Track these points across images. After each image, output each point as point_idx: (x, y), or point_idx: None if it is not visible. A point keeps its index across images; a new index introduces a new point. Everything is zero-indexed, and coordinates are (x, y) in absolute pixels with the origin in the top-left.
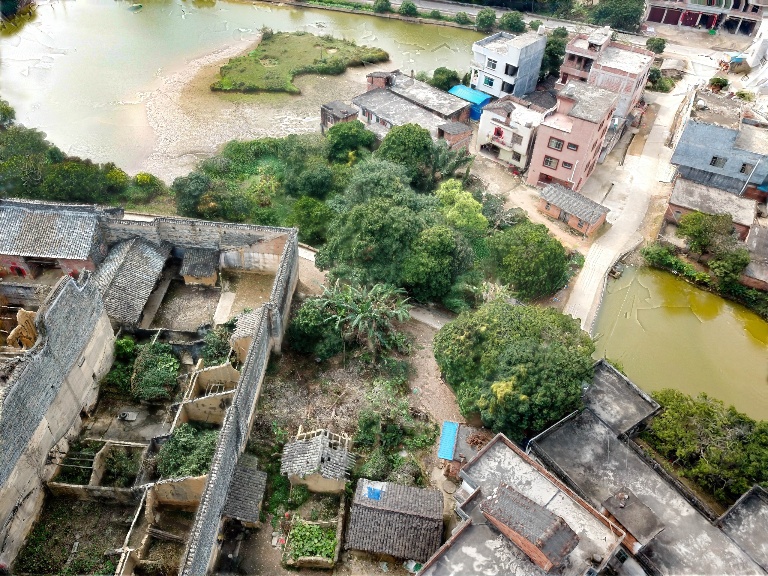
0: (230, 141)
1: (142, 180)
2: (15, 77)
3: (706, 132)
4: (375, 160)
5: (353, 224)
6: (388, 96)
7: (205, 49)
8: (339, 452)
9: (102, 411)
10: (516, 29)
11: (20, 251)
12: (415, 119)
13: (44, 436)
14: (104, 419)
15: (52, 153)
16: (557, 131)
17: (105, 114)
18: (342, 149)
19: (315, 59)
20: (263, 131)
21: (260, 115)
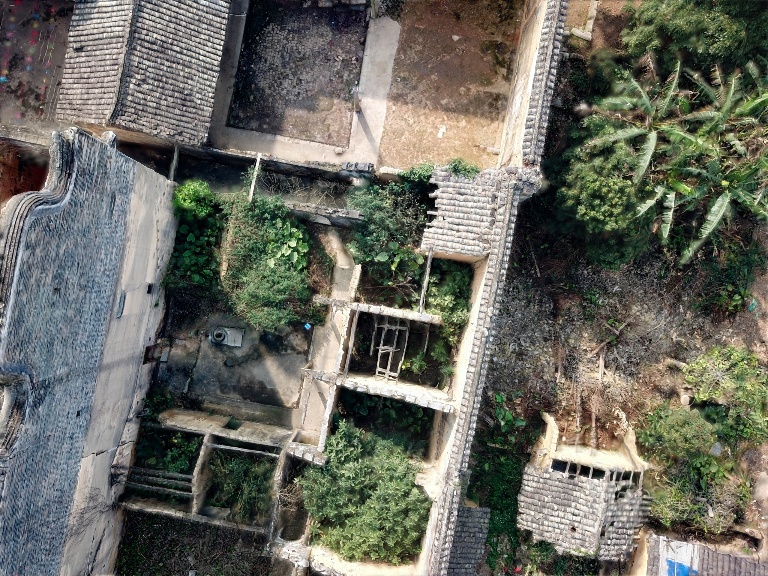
0: None
1: None
2: None
3: None
4: None
5: None
6: None
7: None
8: (629, 503)
9: (179, 322)
10: None
11: None
12: None
13: (94, 473)
14: (186, 341)
15: None
16: None
17: None
18: None
19: None
20: None
21: None
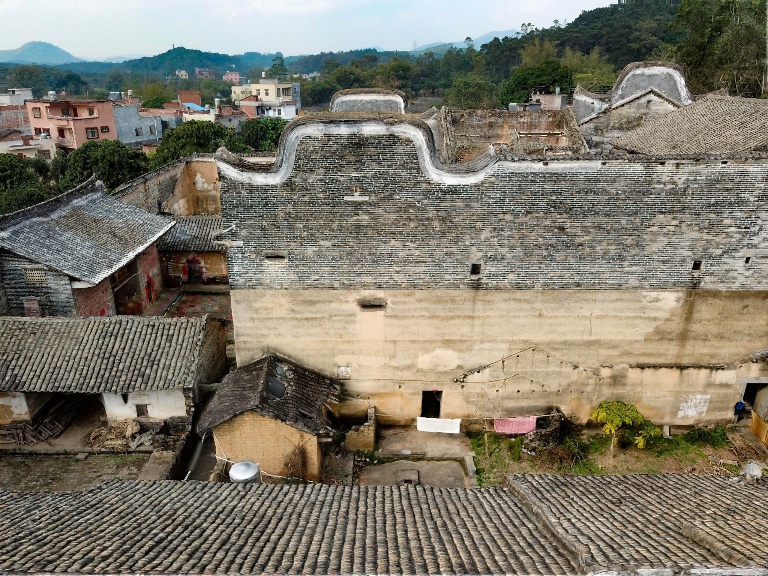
0: None
1: None
2: None
3: (123, 112)
4: None
5: (197, 140)
6: None
7: None
8: None
9: None
10: None
11: (130, 250)
12: None
13: None
14: None
15: None
16: (88, 120)
17: None
18: None
19: None
20: None
21: None
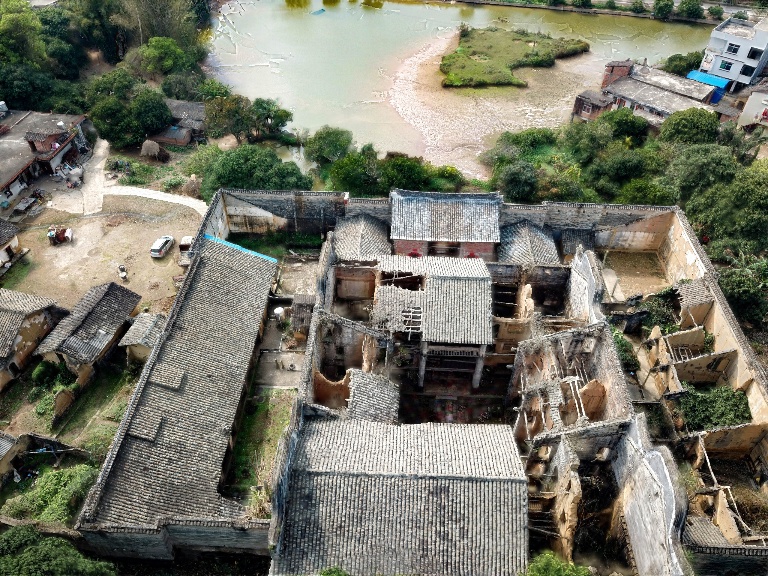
0: (504, 133)
1: (451, 172)
2: (254, 83)
3: None
4: (665, 144)
5: (735, 200)
6: (636, 84)
7: (410, 48)
8: None
9: None
10: (696, 15)
11: (437, 237)
12: (676, 104)
13: None
14: None
15: (369, 150)
16: None
17: (360, 113)
18: (618, 135)
19: (526, 53)
20: (515, 123)
21: (502, 108)
